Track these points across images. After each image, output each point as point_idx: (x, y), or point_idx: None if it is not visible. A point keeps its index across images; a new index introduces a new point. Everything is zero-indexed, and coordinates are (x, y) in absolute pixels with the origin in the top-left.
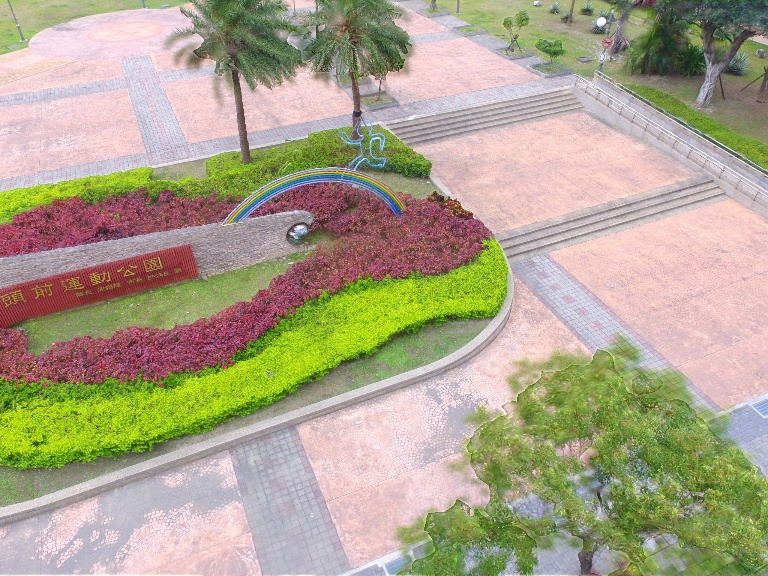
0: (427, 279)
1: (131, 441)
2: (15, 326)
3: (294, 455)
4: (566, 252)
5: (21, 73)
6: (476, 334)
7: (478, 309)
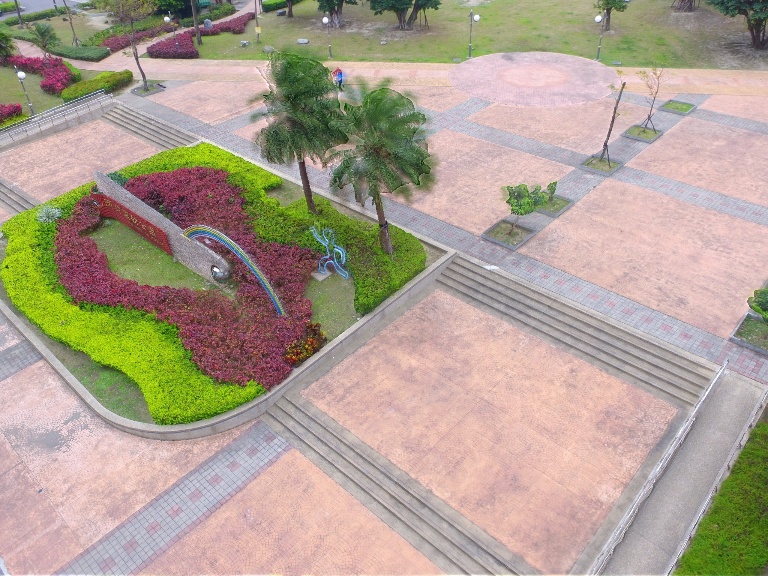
0: (187, 363)
1: (9, 295)
2: (115, 219)
3: (18, 367)
4: (301, 462)
5: (411, 81)
6: (138, 420)
7: (149, 405)
